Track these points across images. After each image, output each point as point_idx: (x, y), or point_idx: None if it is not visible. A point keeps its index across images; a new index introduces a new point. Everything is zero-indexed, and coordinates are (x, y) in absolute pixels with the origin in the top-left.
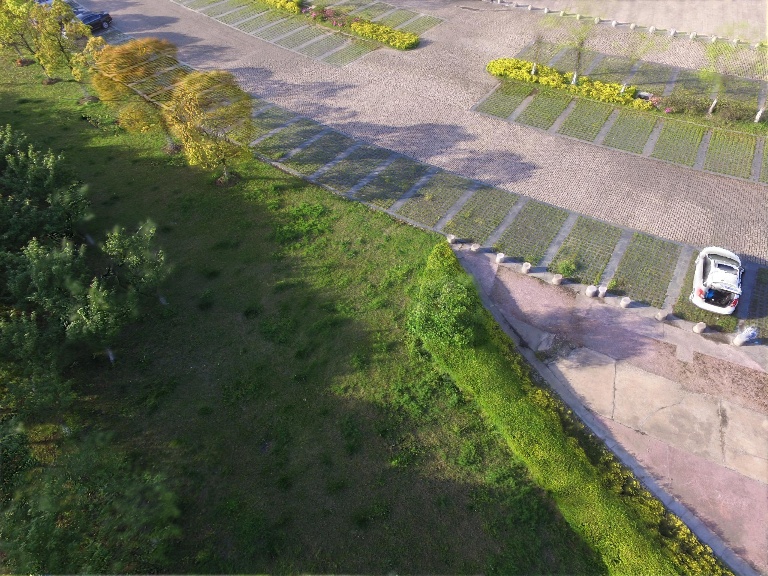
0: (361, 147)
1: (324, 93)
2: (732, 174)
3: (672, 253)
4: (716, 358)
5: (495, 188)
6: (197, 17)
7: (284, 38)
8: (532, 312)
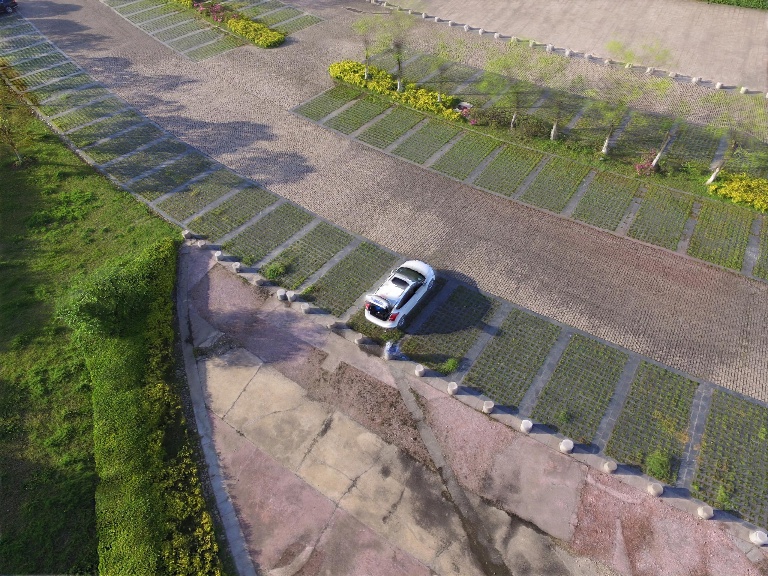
0: (165, 140)
1: (166, 86)
2: (496, 190)
3: (385, 264)
4: (358, 369)
5: (262, 188)
6: (98, 6)
7: (164, 31)
8: (217, 310)
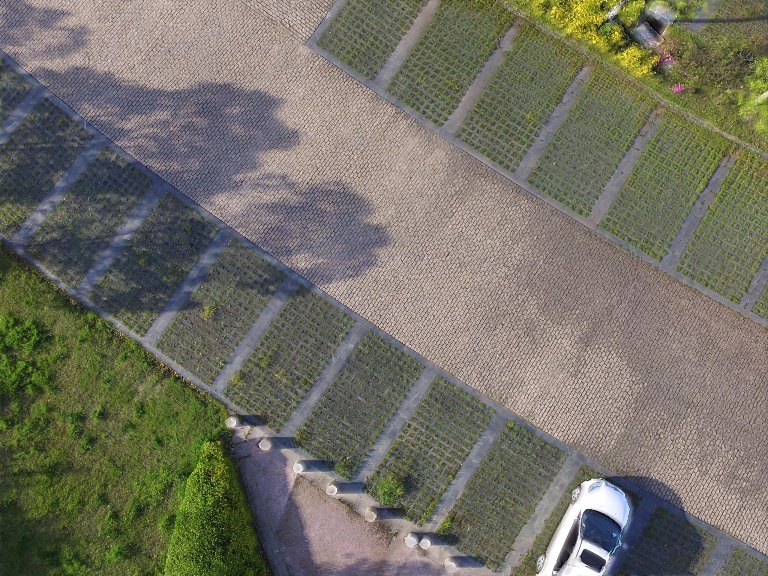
0: (99, 157)
1: None
2: (717, 289)
3: (549, 468)
4: None
5: (320, 295)
6: None
7: None
8: (326, 567)
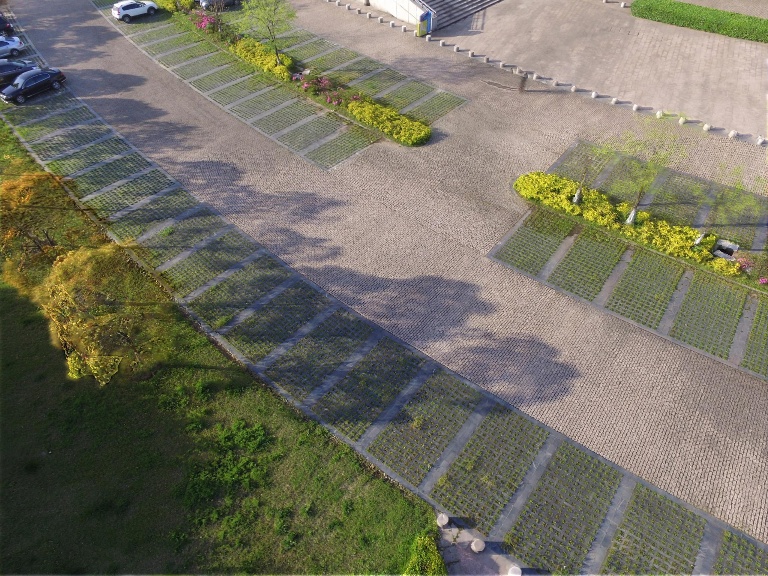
0: (334, 313)
1: (300, 211)
2: None
3: None
4: None
5: (515, 411)
6: (168, 79)
7: (265, 117)
8: None
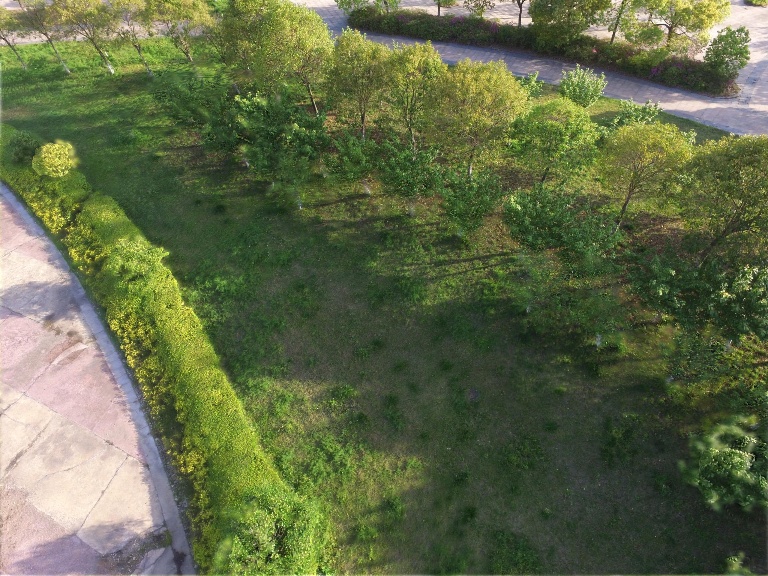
0: None
1: None
2: None
3: None
4: None
5: None
6: None
7: None
8: None
